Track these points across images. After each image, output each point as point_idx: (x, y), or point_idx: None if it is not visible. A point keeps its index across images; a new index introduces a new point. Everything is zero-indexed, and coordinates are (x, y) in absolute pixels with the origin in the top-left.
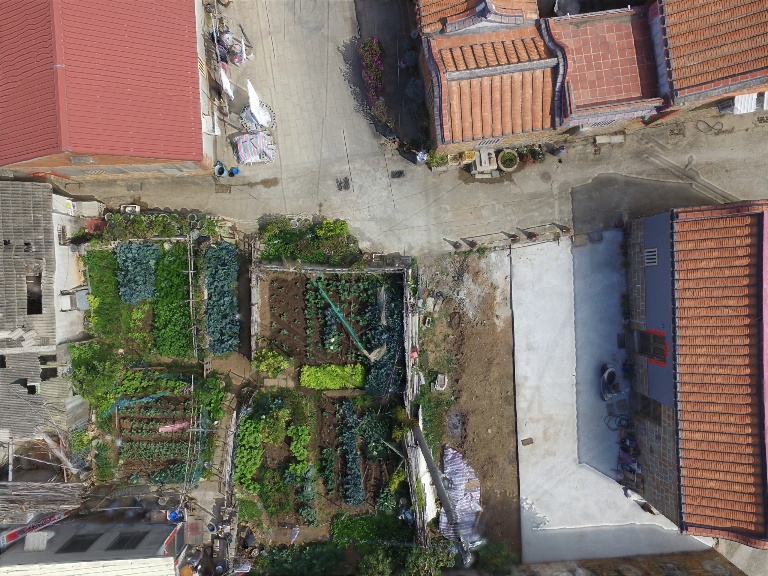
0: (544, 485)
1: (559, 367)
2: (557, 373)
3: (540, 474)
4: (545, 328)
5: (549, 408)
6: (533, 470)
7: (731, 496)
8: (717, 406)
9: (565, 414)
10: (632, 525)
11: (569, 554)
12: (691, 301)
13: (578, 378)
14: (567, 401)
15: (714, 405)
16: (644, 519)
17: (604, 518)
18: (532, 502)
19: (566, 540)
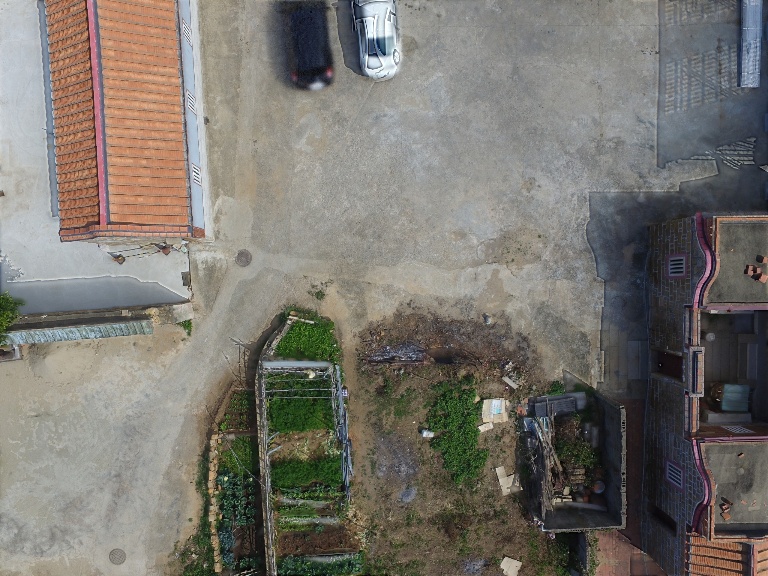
0: (17, 238)
1: (30, 121)
2: (28, 127)
3: (13, 227)
4: (14, 82)
5: (21, 162)
6: (6, 223)
7: (85, 192)
8: (74, 106)
9: (37, 168)
10: (108, 278)
11: (46, 307)
12: (53, 6)
13: (49, 132)
14: (39, 155)
15: (73, 106)
16: (119, 271)
17: (79, 271)
18: (5, 255)
19: (42, 293)
